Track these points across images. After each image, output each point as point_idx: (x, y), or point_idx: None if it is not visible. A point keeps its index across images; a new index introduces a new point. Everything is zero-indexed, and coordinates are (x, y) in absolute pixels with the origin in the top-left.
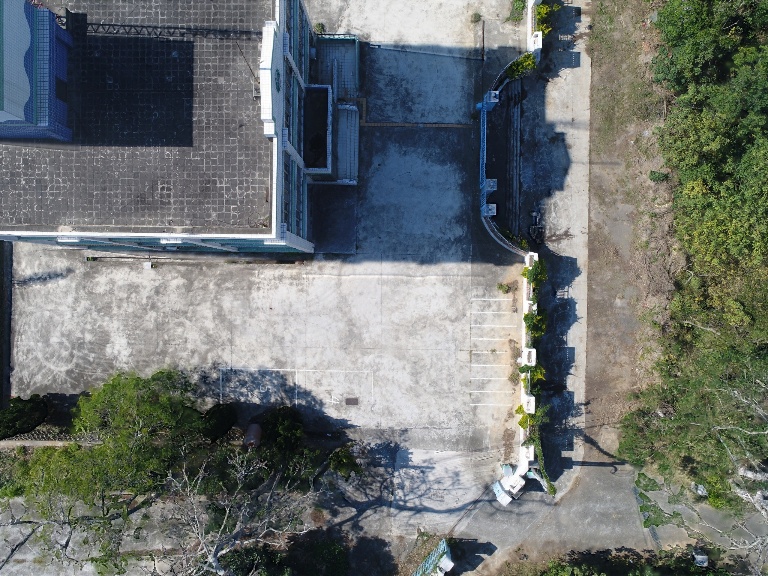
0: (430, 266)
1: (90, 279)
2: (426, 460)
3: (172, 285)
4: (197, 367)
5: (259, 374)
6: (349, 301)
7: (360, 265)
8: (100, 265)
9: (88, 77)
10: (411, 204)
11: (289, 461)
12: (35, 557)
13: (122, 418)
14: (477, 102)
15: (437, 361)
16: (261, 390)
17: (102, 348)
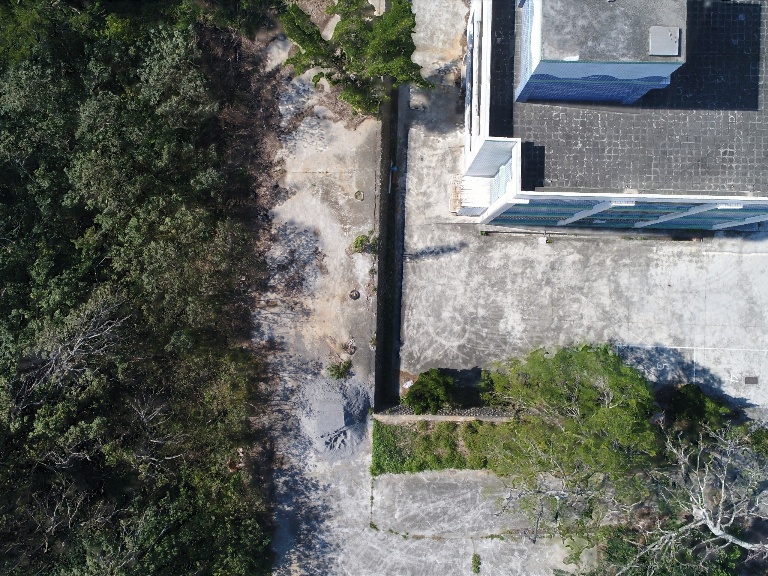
0: None
1: (484, 253)
2: None
3: (568, 261)
4: (593, 344)
5: (656, 351)
6: (750, 279)
7: (762, 243)
8: (494, 240)
9: None
10: None
11: None
12: (434, 533)
13: (592, 390)
14: None
15: None
16: (658, 368)
17: (495, 323)
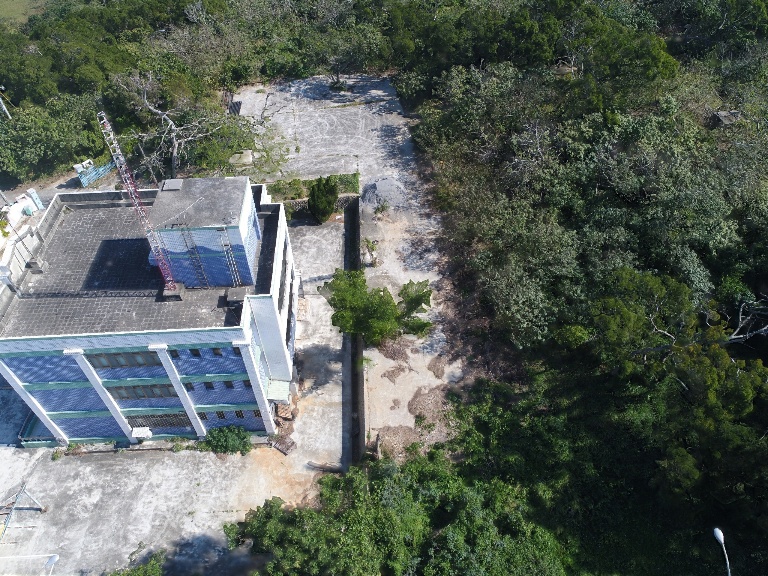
0: None
1: None
2: None
3: None
4: None
5: None
6: None
7: None
8: None
9: None
10: None
11: None
12: None
13: None
14: None
15: None
16: None
17: None
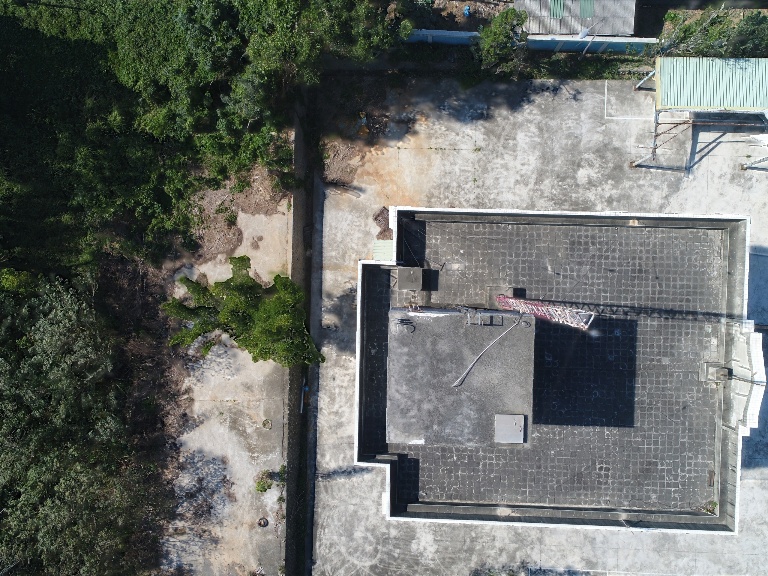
0: (748, 470)
1: None
2: None
3: None
4: (505, 566)
5: (569, 574)
6: None
7: None
8: None
9: None
10: None
11: None
12: None
13: None
14: None
15: (753, 566)
16: None
17: (407, 544)
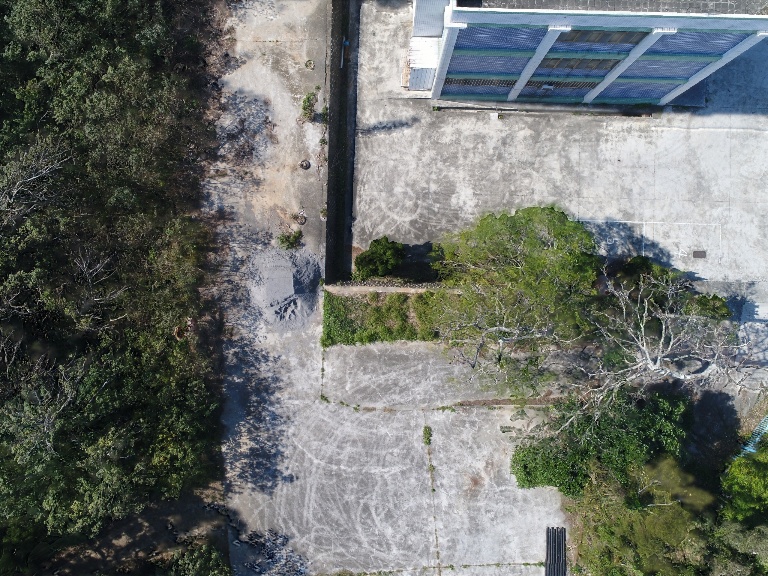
0: None
1: (436, 129)
2: None
3: (519, 136)
4: None
5: (606, 226)
6: (698, 154)
7: (709, 118)
8: (446, 115)
9: None
10: (761, 58)
11: (664, 302)
12: (385, 405)
13: (537, 240)
14: None
15: None
16: (608, 242)
17: (447, 198)
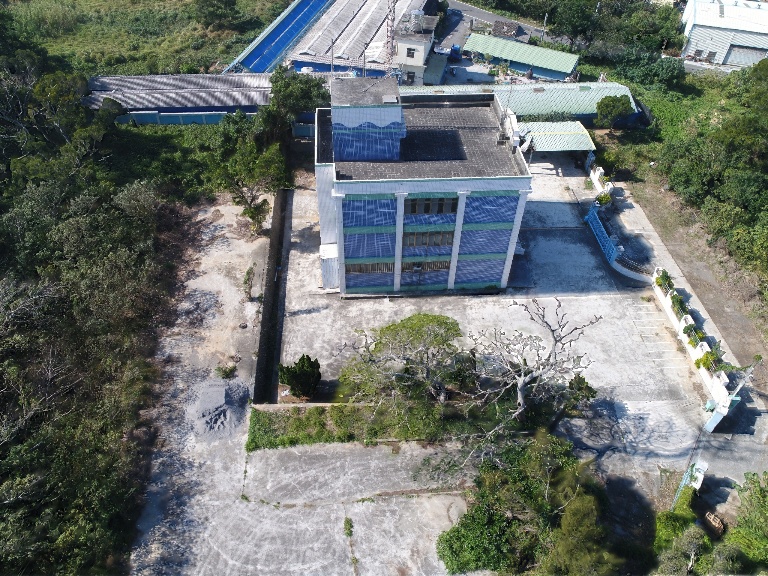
0: (589, 291)
1: (344, 309)
2: (640, 409)
3: (406, 310)
4: None
5: (484, 358)
6: None
7: (540, 292)
8: (351, 301)
9: (405, 141)
10: (563, 262)
11: None
12: (305, 501)
13: None
14: (583, 218)
15: (618, 342)
16: (489, 368)
17: None
